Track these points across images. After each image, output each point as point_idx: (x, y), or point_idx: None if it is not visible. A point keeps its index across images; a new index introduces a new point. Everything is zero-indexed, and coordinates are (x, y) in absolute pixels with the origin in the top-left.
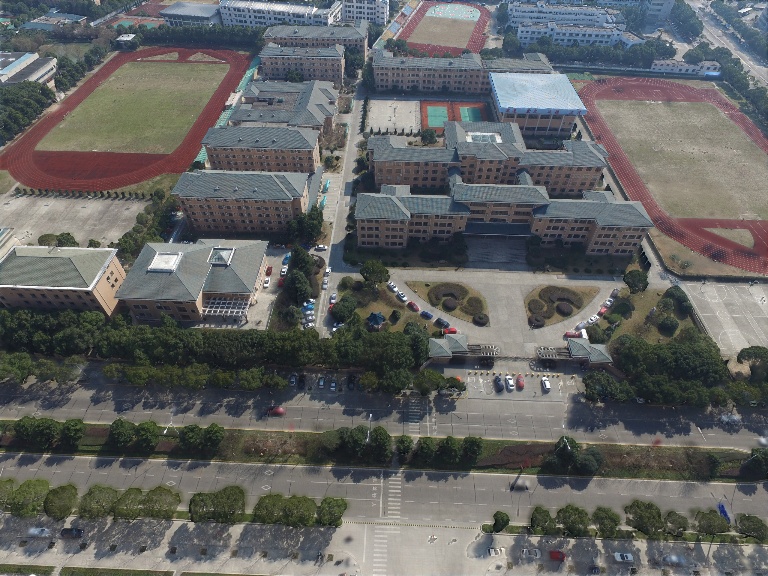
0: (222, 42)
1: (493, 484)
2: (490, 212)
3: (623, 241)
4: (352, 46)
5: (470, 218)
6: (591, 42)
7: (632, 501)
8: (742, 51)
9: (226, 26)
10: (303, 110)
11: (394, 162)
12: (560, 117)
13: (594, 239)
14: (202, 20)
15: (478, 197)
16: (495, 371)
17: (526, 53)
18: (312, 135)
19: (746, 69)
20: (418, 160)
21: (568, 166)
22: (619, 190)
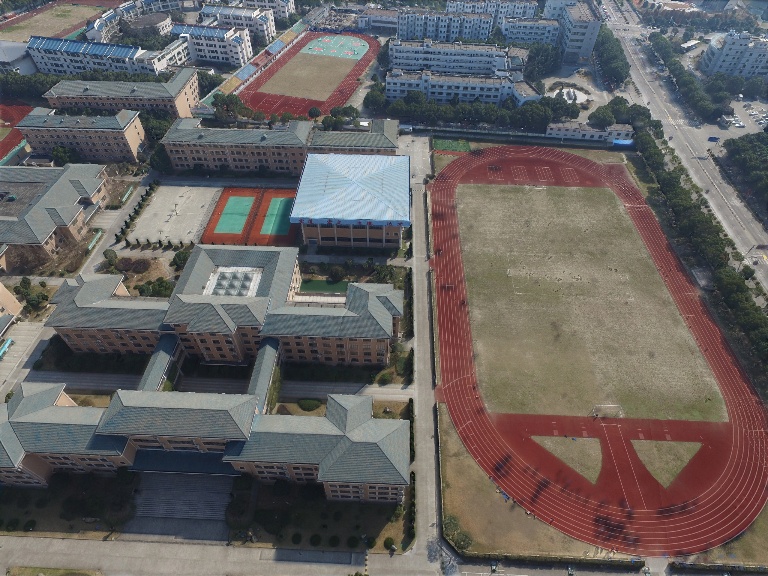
0: (22, 94)
1: None
2: (166, 441)
3: (374, 491)
4: (160, 106)
5: (142, 445)
6: (476, 96)
7: None
8: (674, 103)
9: (22, 75)
10: (19, 220)
11: (78, 328)
12: (380, 227)
13: (327, 488)
14: (4, 65)
15: (133, 427)
16: None
17: (374, 119)
18: None
19: (671, 132)
20: (110, 327)
21: (333, 337)
22: (430, 354)
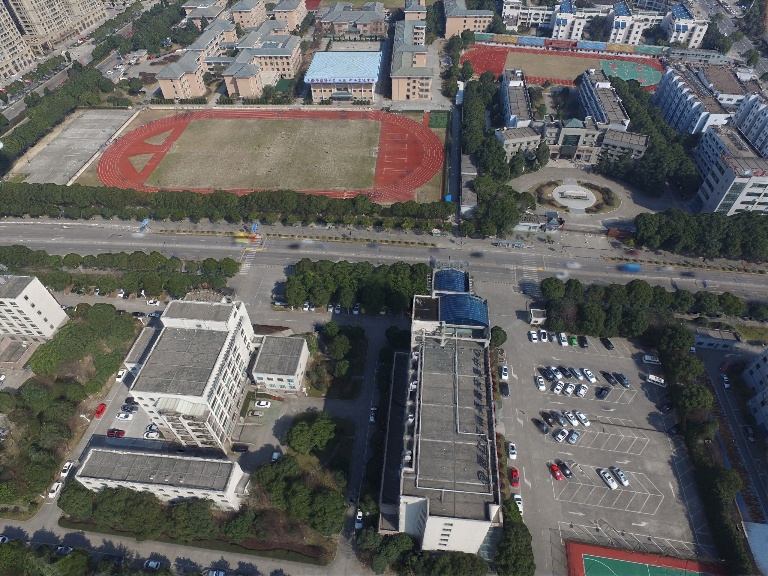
0: None
1: (85, 63)
2: None
3: None
4: None
5: None
6: None
7: (55, 82)
8: None
9: None
10: None
11: None
12: None
13: None
14: None
15: None
16: (126, 65)
17: None
18: (285, 7)
19: (497, 259)
20: None
21: None
22: None
